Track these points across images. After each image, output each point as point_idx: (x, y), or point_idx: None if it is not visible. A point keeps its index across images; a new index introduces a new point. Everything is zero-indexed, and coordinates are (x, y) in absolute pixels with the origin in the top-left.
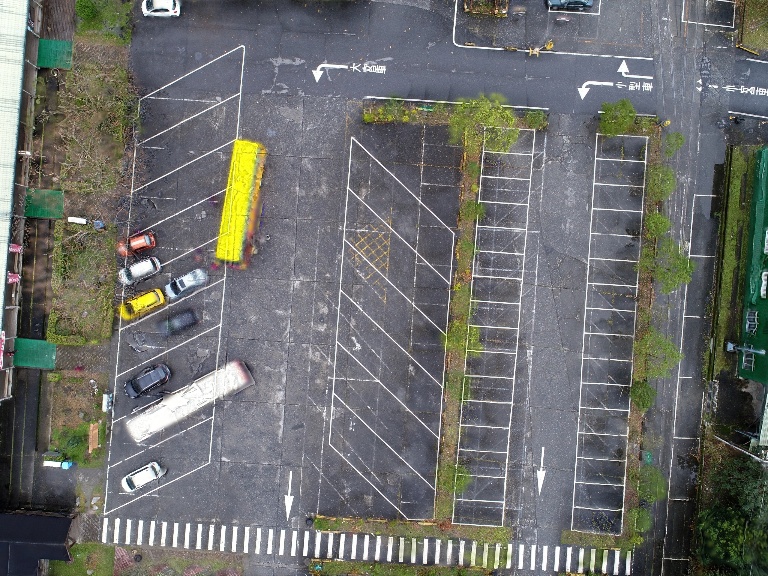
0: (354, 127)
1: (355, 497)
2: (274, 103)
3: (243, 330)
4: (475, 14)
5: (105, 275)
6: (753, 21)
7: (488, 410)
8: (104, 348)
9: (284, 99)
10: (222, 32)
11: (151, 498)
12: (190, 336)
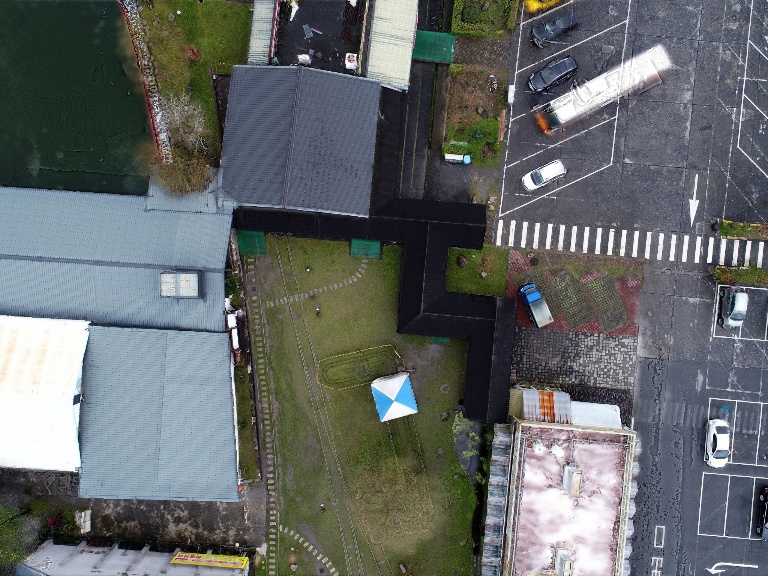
0: None
1: (763, 203)
2: None
3: (651, 26)
4: None
5: None
6: None
7: None
8: (504, 43)
9: None
10: None
11: (549, 200)
12: (595, 32)
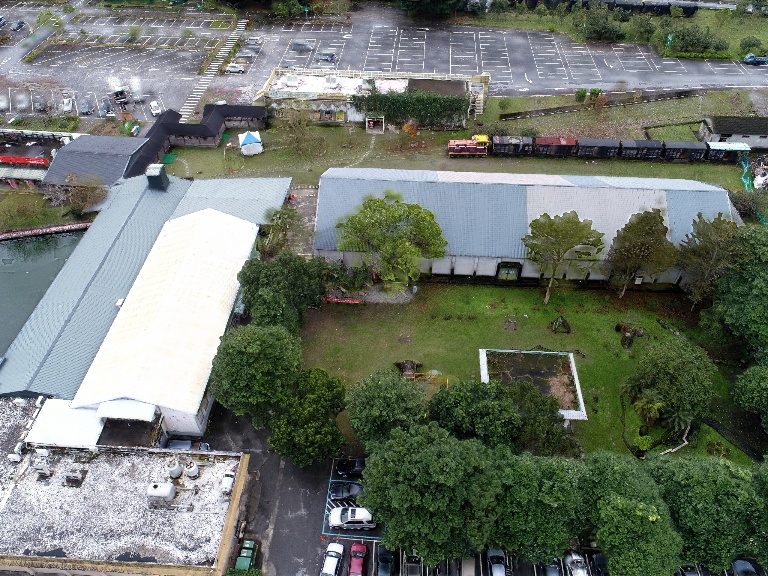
0: (29, 64)
1: (193, 65)
2: (1, 80)
3: None
4: (5, 42)
5: None
6: (56, 1)
7: (171, 41)
8: None
9: (1, 78)
10: None
11: None
12: None
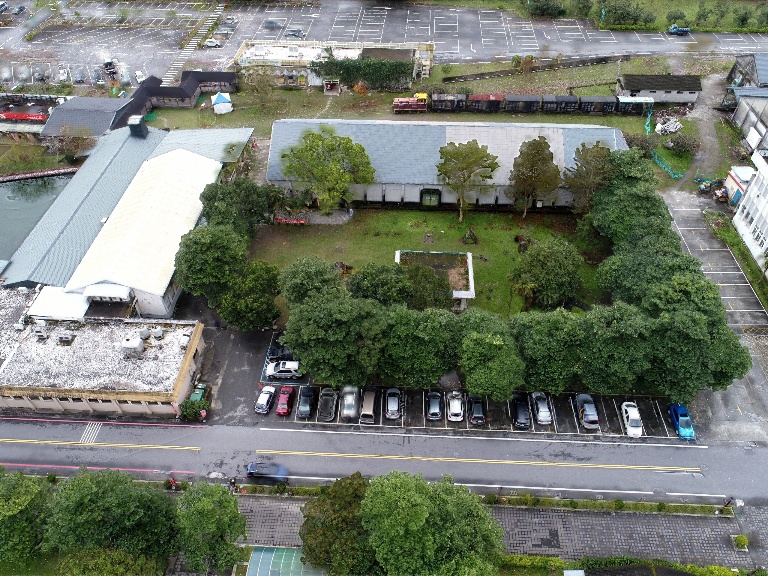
0: None
1: (175, 41)
2: None
3: None
4: (8, 24)
5: None
6: None
7: None
8: None
9: None
10: None
11: None
12: None
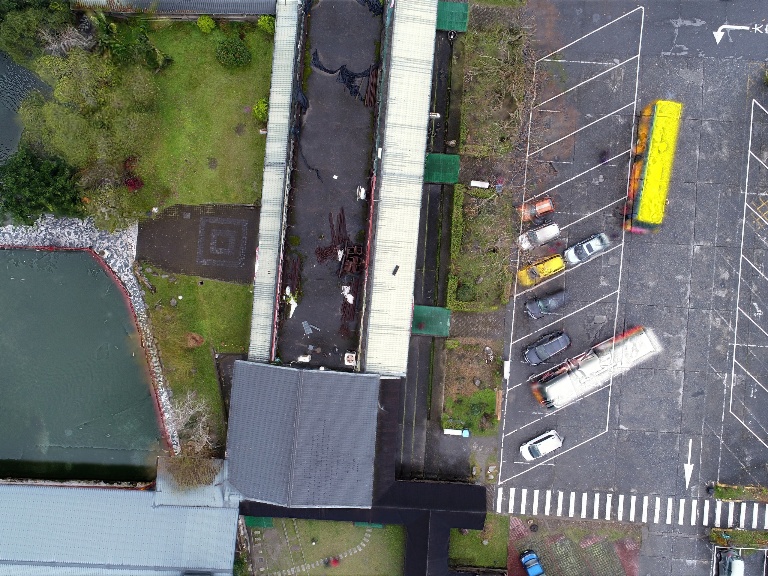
0: (756, 89)
1: (756, 465)
2: (673, 65)
3: (642, 296)
4: None
5: (501, 240)
6: None
7: None
8: (499, 315)
9: (684, 61)
10: None
11: (547, 467)
12: (587, 302)
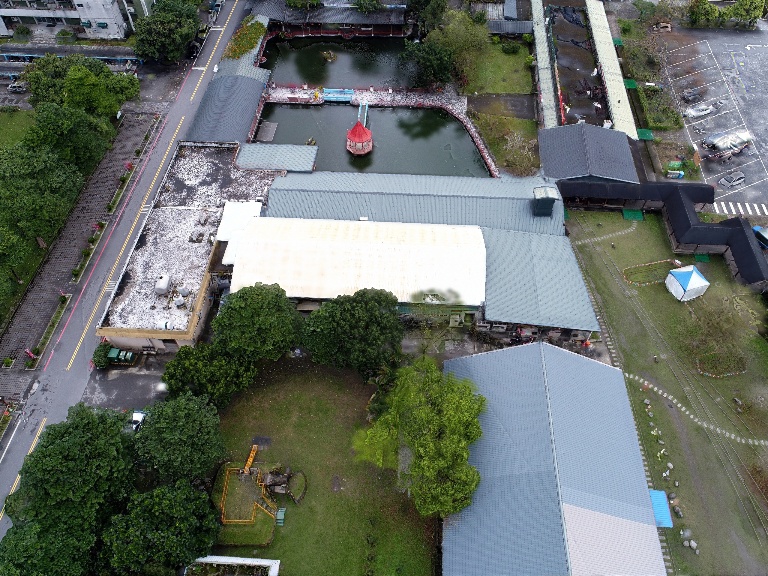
0: None
1: None
2: None
3: (759, 126)
4: None
5: None
6: None
7: None
8: None
9: None
10: (693, 37)
11: (740, 193)
12: (729, 128)
